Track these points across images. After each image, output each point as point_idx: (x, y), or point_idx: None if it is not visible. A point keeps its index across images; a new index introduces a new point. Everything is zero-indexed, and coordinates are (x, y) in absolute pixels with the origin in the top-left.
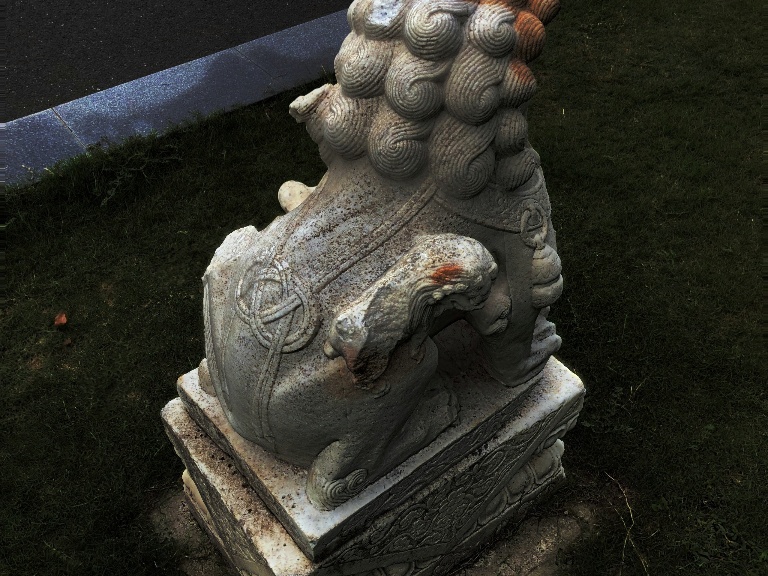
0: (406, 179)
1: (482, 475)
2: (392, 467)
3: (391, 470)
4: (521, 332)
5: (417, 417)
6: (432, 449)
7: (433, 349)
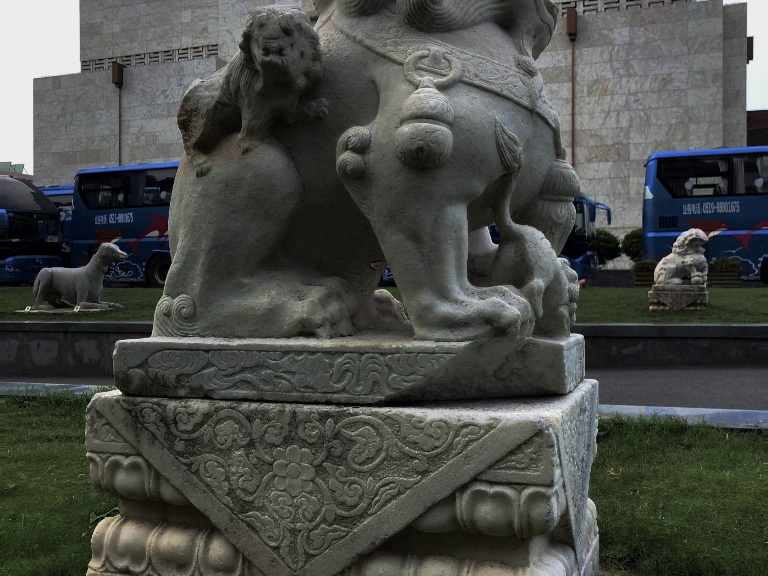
0: (323, 8)
1: (344, 457)
2: (227, 331)
3: (227, 337)
4: (394, 204)
5: (273, 285)
6: (277, 341)
7: (271, 157)
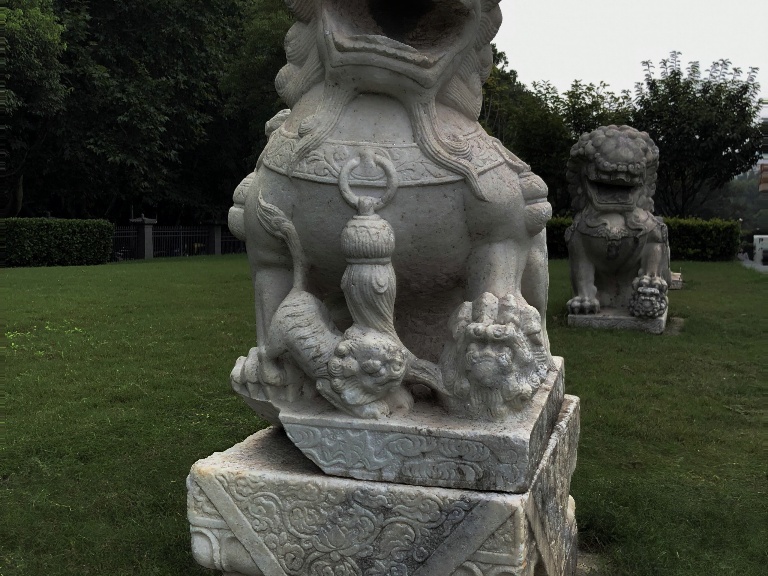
0: None
1: None
2: None
3: None
4: None
5: None
6: None
7: None
